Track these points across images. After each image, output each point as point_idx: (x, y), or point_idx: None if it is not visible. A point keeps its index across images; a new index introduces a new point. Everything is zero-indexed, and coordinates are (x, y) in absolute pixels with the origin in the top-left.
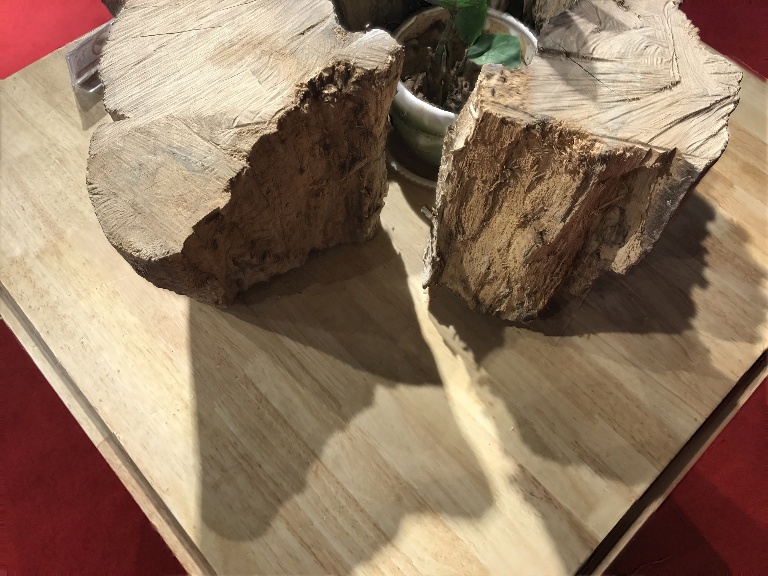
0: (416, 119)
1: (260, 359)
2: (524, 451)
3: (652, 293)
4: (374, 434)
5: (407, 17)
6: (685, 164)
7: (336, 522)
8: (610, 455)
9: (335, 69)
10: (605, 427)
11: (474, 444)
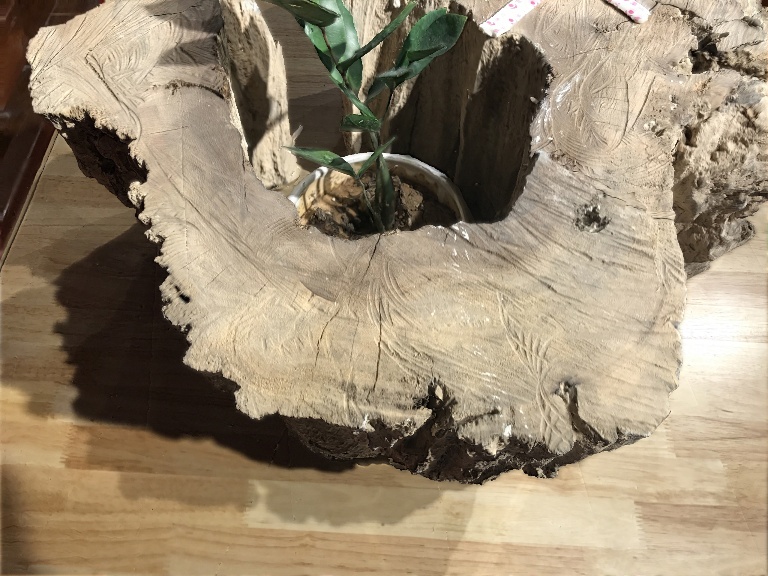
0: None
1: None
2: None
3: (103, 288)
4: None
5: (470, 220)
6: None
7: None
8: None
9: None
10: None
11: None
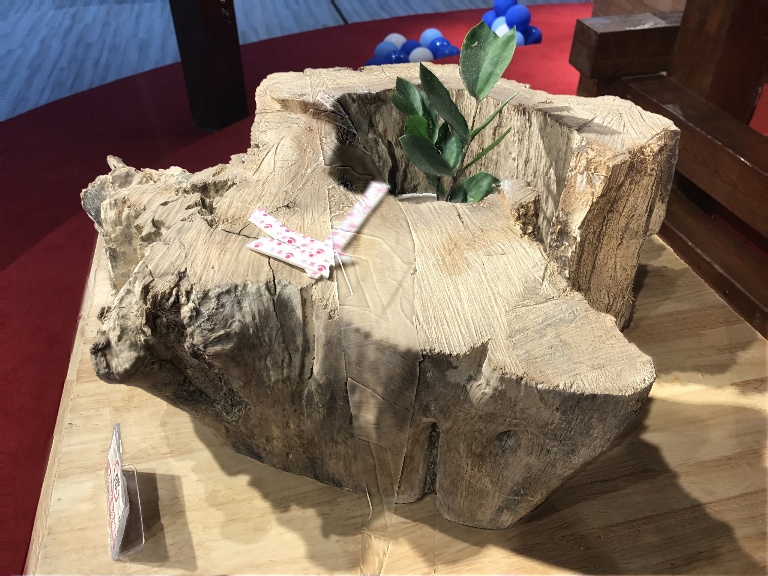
0: None
1: (587, 509)
2: (721, 378)
3: None
4: (686, 458)
5: None
6: (671, 133)
7: (766, 515)
8: (731, 339)
9: (521, 214)
10: (710, 332)
11: (709, 401)
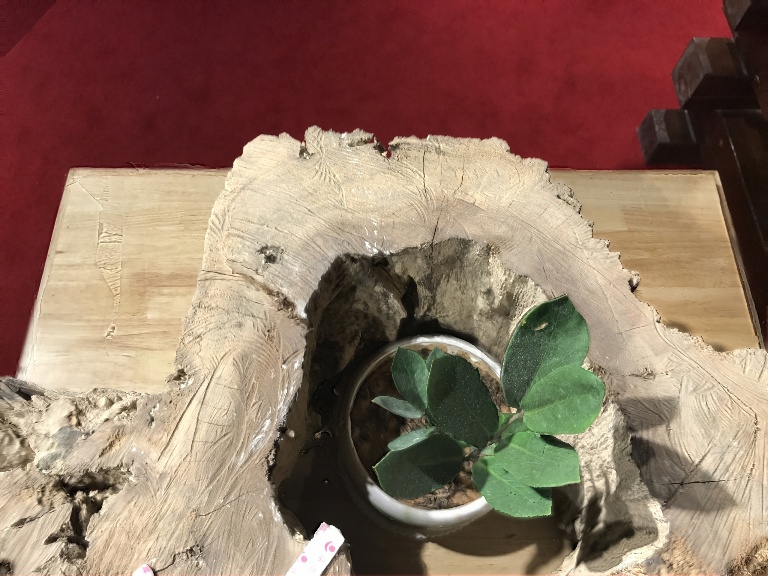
0: (454, 523)
1: None
2: None
3: None
4: None
5: (345, 428)
6: None
7: None
8: None
9: None
10: None
11: None
